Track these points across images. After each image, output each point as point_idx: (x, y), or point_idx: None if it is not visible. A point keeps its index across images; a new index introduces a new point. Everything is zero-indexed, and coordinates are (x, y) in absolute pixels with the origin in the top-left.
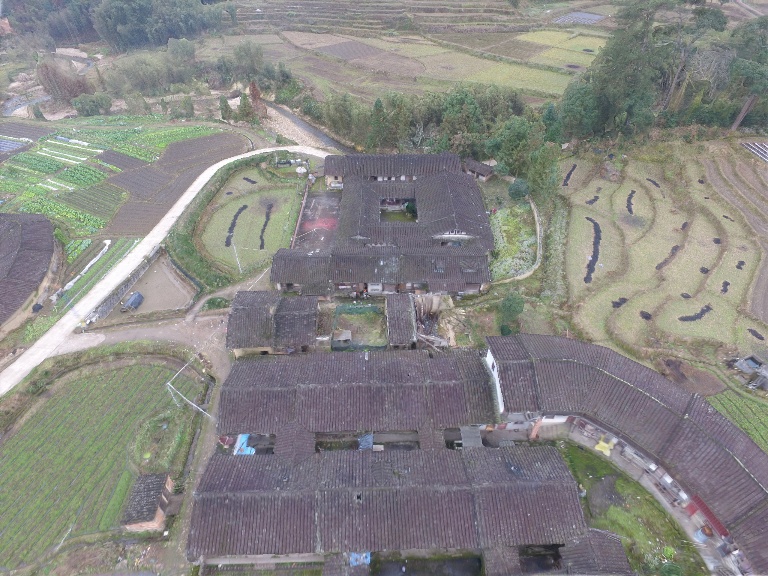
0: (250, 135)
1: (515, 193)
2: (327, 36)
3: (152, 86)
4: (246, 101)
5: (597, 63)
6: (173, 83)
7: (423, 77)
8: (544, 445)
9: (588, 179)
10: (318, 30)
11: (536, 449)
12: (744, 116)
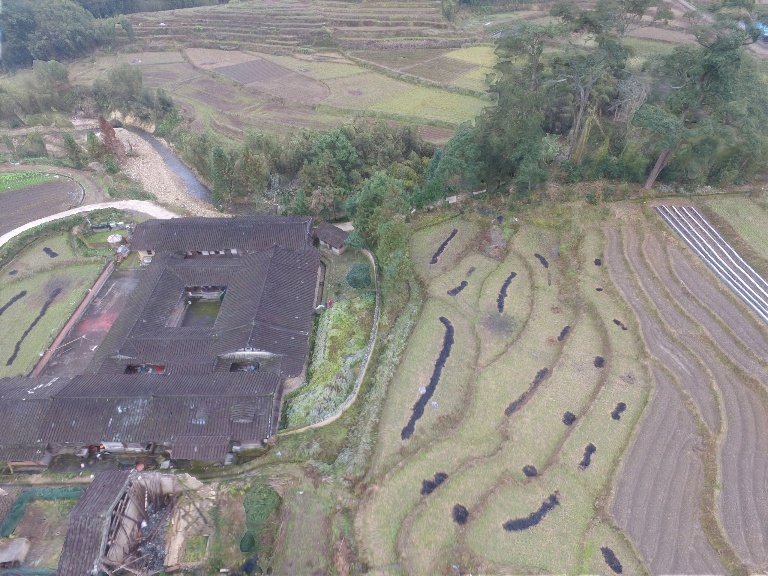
0: (87, 184)
1: (354, 282)
2: (235, 53)
3: (12, 116)
4: (94, 140)
5: None
6: None
7: (322, 105)
8: None
9: (465, 252)
10: (226, 46)
11: None
12: (659, 172)
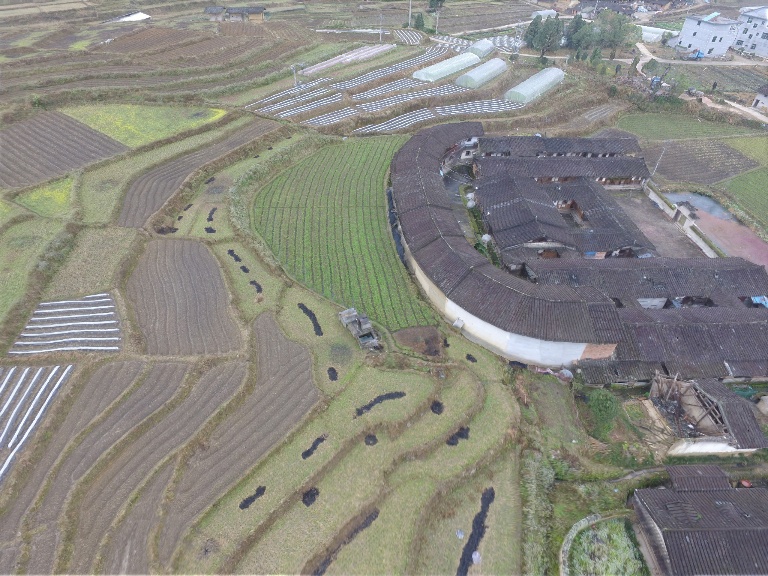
0: None
1: None
2: None
3: None
4: None
5: None
6: None
7: None
8: None
9: None
10: None
11: None
12: None
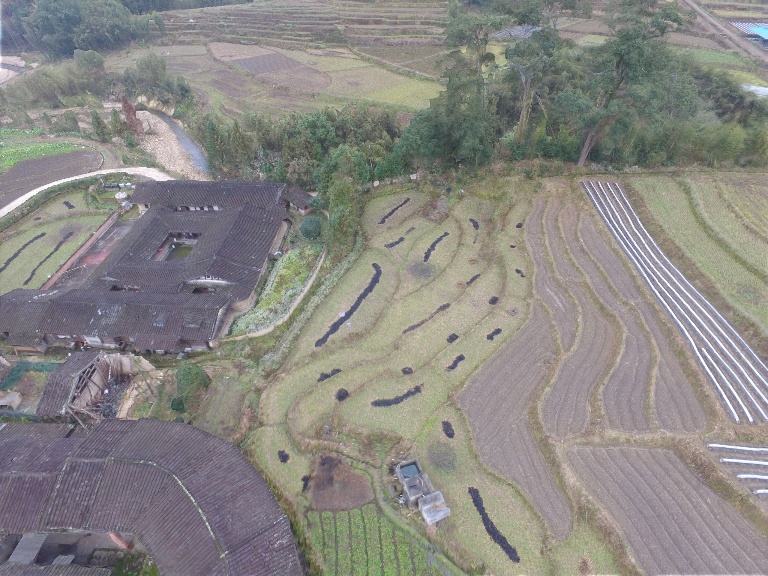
0: (107, 154)
1: (306, 232)
2: (253, 48)
3: (54, 98)
4: (116, 117)
5: (494, 83)
6: None
7: (321, 94)
8: (138, 558)
9: None
10: (246, 41)
11: (85, 572)
12: (589, 151)
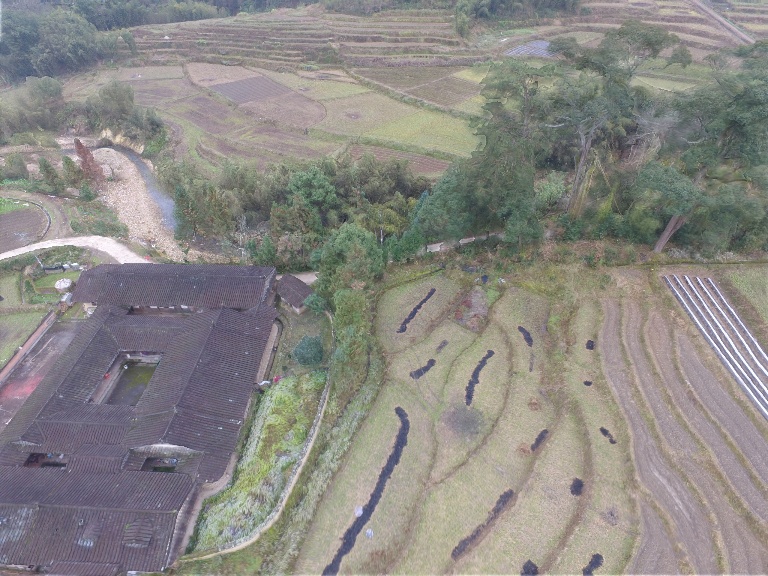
0: (55, 214)
1: (303, 357)
2: (237, 69)
3: (2, 133)
4: (69, 165)
5: None
6: (28, 130)
7: (315, 129)
8: None
9: (440, 319)
10: (229, 62)
11: None
12: (671, 235)
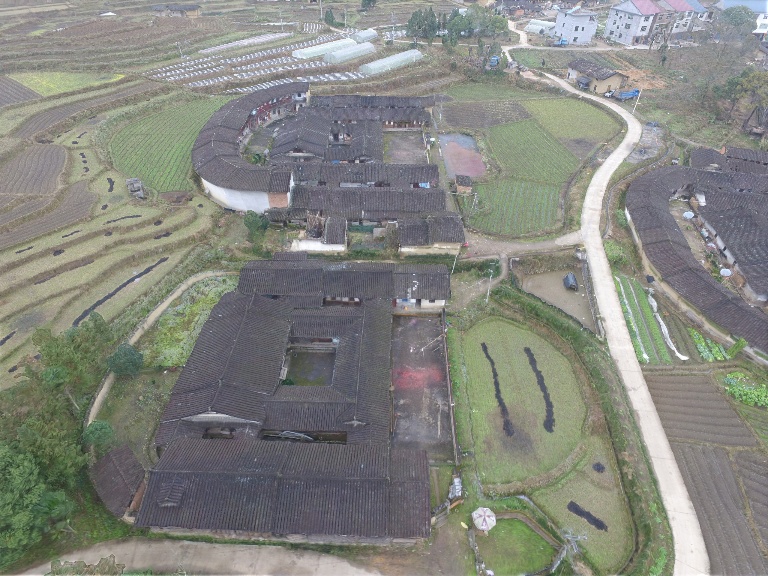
0: None
1: None
2: None
3: None
4: None
5: None
6: None
7: None
8: None
9: None
10: None
11: None
12: None
